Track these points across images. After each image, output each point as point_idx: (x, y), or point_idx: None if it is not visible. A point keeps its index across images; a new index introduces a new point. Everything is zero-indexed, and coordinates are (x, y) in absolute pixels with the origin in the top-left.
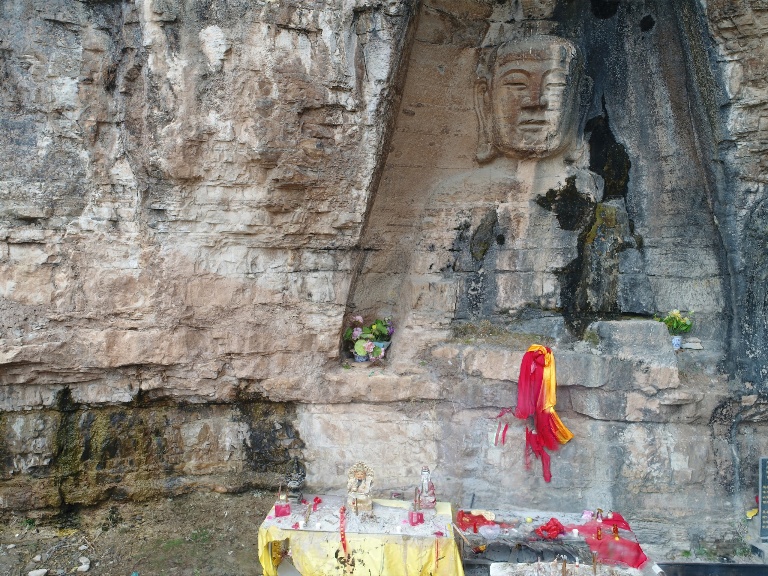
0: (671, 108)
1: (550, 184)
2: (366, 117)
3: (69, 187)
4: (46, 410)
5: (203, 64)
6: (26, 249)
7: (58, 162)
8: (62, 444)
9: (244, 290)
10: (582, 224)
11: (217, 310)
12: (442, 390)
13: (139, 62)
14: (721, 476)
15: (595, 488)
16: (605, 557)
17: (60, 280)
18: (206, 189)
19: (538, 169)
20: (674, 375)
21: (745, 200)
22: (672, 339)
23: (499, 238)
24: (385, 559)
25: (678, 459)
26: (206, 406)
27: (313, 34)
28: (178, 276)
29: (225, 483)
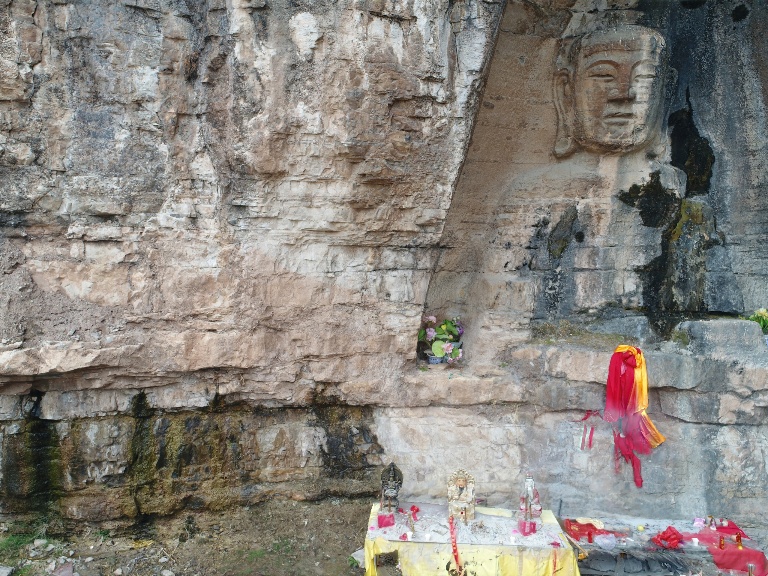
0: (763, 101)
1: (634, 179)
2: (456, 109)
3: (148, 182)
4: (120, 416)
5: (292, 53)
6: (102, 247)
7: (136, 156)
8: (137, 451)
9: (323, 290)
10: (667, 221)
11: (296, 311)
12: (525, 392)
13: (224, 51)
14: None
15: (688, 493)
16: (729, 567)
17: (137, 280)
18: (289, 184)
19: (621, 164)
20: None
21: None
22: None
23: (578, 235)
24: (500, 571)
25: None
26: (281, 410)
27: (406, 22)
28: (258, 275)
29: (303, 490)
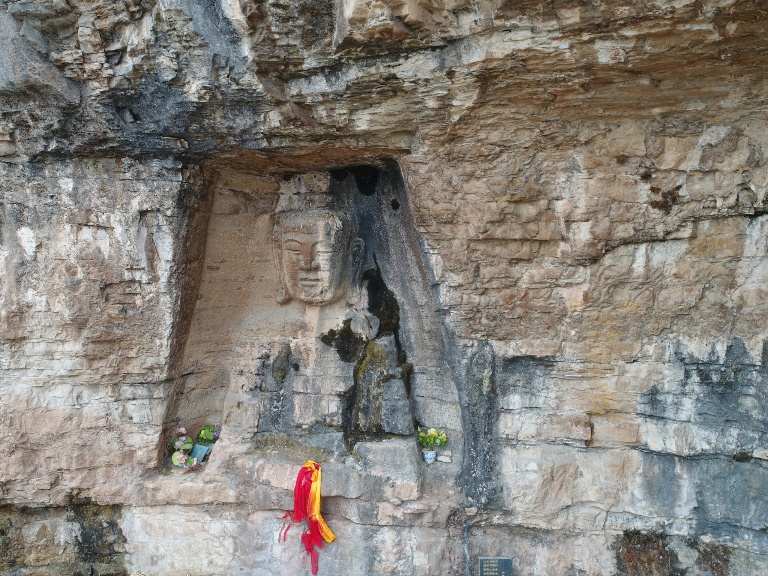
0: (418, 270)
1: (330, 325)
2: (160, 287)
3: None
4: None
5: (21, 254)
6: None
7: None
8: None
9: (72, 418)
10: (356, 358)
11: (49, 435)
12: (239, 495)
13: None
14: (454, 570)
15: None
16: None
17: None
18: (32, 344)
19: (321, 313)
20: (414, 490)
21: (465, 352)
22: (427, 454)
23: (294, 366)
24: None
25: (420, 556)
26: (45, 509)
27: (109, 229)
28: (13, 411)
29: (57, 573)
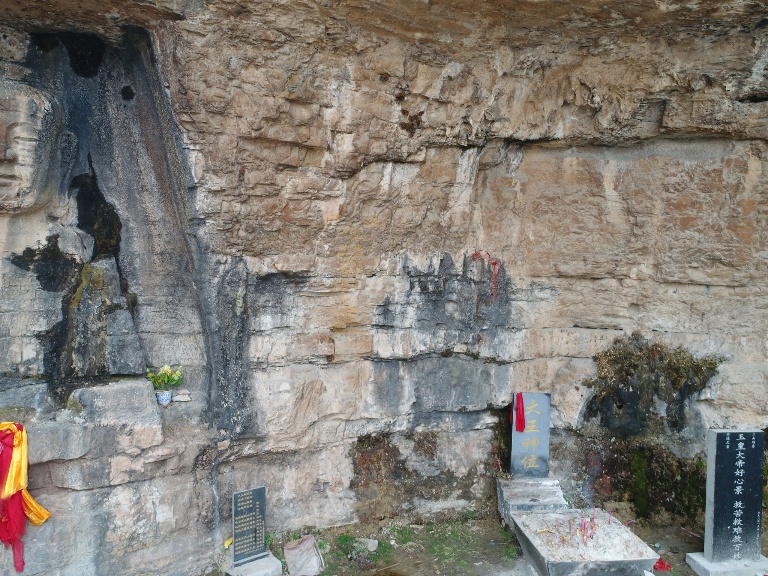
0: (155, 177)
1: (27, 242)
2: None
3: None
4: None
5: None
6: None
7: None
8: None
9: None
10: (66, 286)
11: None
12: None
13: None
14: (203, 516)
15: (76, 563)
16: None
17: None
18: None
19: (12, 225)
20: (157, 433)
21: (217, 270)
22: (162, 395)
23: None
24: None
25: (163, 511)
26: None
27: None
28: None
29: None
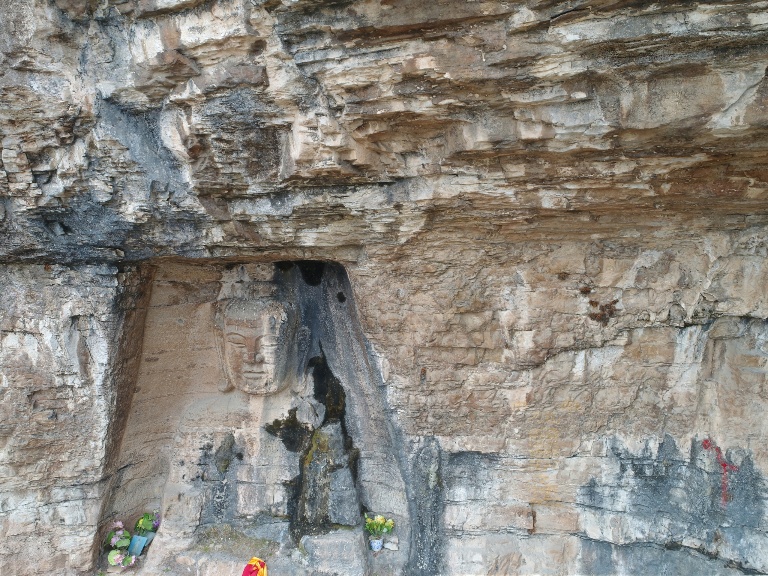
0: (365, 362)
1: (275, 416)
2: (94, 390)
3: None
4: None
5: None
6: None
7: None
8: None
9: None
10: (302, 448)
11: None
12: None
13: None
14: None
15: None
16: None
17: None
18: None
19: (266, 402)
20: None
21: (411, 447)
22: (374, 542)
23: (238, 455)
24: None
25: None
26: None
27: (38, 334)
28: None
29: None
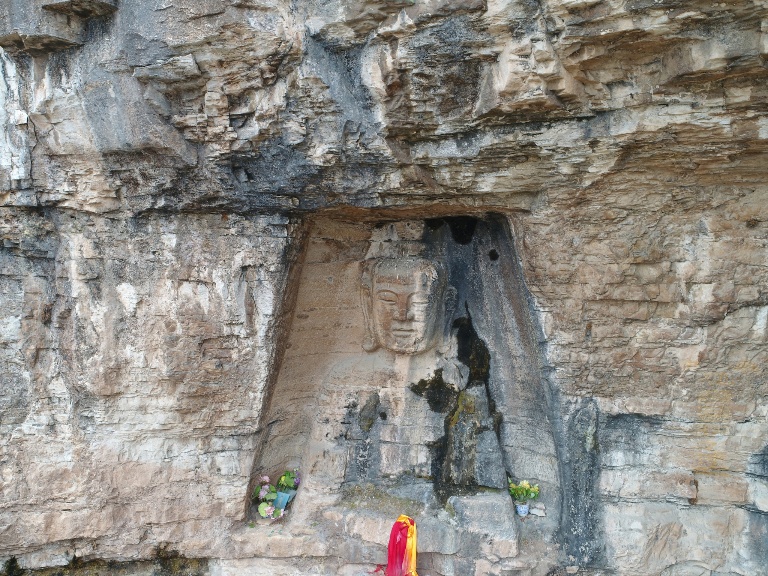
0: (516, 322)
1: (421, 375)
2: (257, 341)
3: (14, 401)
4: None
5: (120, 310)
6: None
7: (5, 381)
8: None
9: (162, 471)
10: (447, 409)
11: (139, 489)
12: (329, 549)
13: (69, 307)
14: None
15: None
16: None
17: (7, 474)
18: (126, 399)
19: (412, 362)
20: (512, 547)
21: (568, 408)
22: (520, 507)
23: (382, 415)
24: None
25: None
26: (132, 563)
27: (210, 284)
28: (105, 465)
29: None
